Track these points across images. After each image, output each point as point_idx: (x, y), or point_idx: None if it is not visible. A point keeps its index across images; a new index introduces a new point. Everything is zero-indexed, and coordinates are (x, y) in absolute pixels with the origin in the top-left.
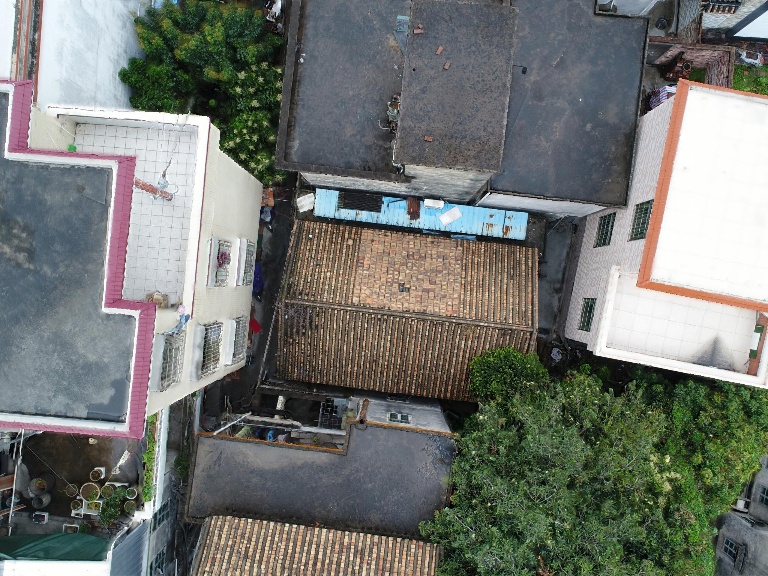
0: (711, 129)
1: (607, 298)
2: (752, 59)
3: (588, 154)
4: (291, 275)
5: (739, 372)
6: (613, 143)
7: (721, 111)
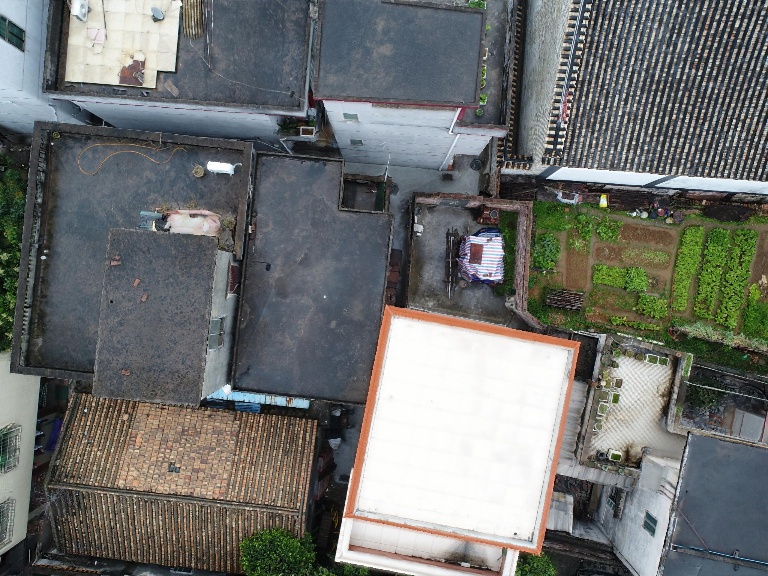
0: (417, 357)
1: (346, 503)
2: (568, 199)
3: (333, 352)
4: (58, 456)
5: (491, 568)
6: (358, 340)
7: (427, 339)
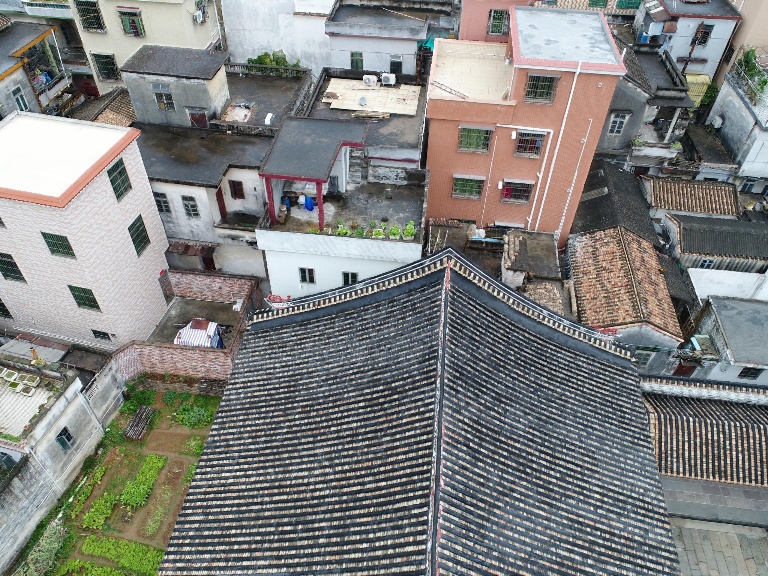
0: (99, 138)
1: None
2: None
3: None
4: None
5: None
6: None
7: None
